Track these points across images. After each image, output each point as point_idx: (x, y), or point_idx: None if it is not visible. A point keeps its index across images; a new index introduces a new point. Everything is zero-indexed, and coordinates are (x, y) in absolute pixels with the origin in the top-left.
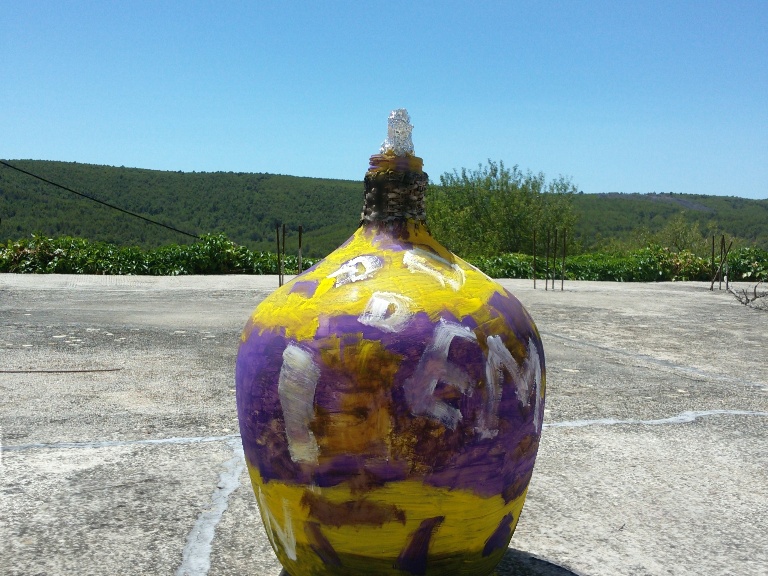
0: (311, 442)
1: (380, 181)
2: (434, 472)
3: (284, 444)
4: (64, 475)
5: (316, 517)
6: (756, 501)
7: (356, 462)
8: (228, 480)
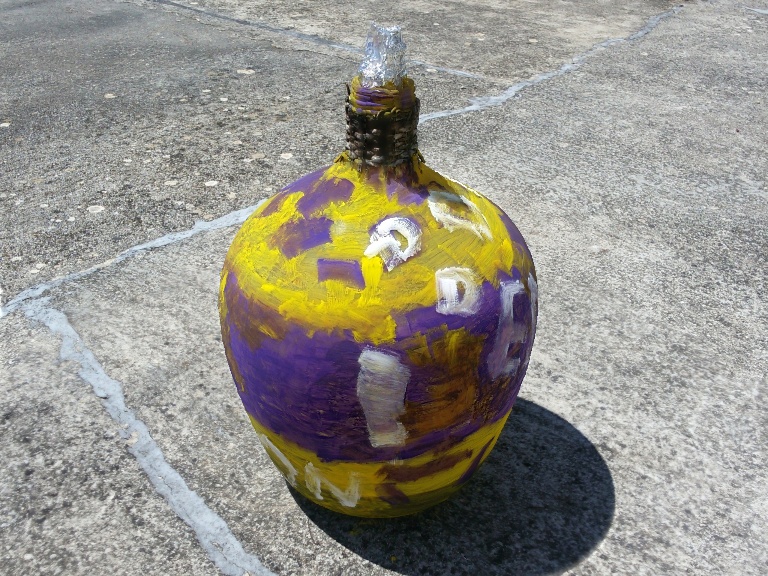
0: (399, 431)
1: (385, 122)
2: (498, 413)
3: (364, 436)
4: None
5: (393, 480)
6: (542, 245)
7: (443, 434)
8: (99, 381)
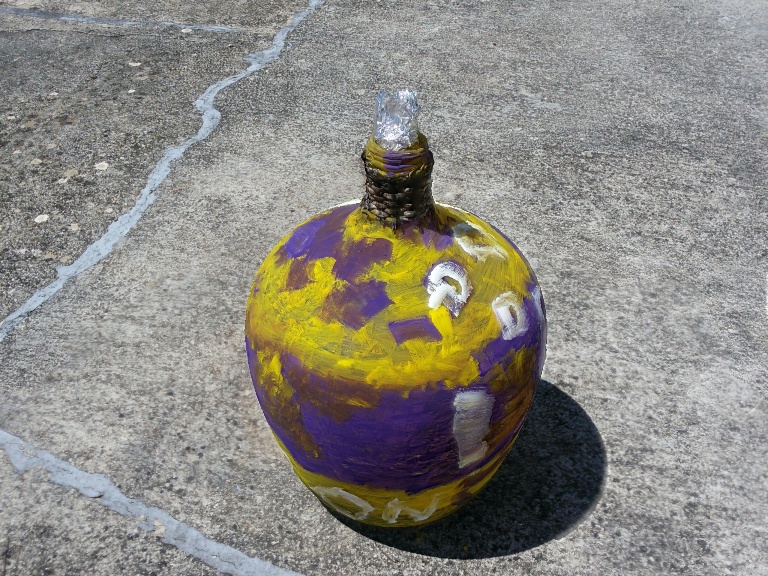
0: None
1: (416, 180)
2: None
3: None
4: None
5: None
6: None
7: None
8: (80, 481)
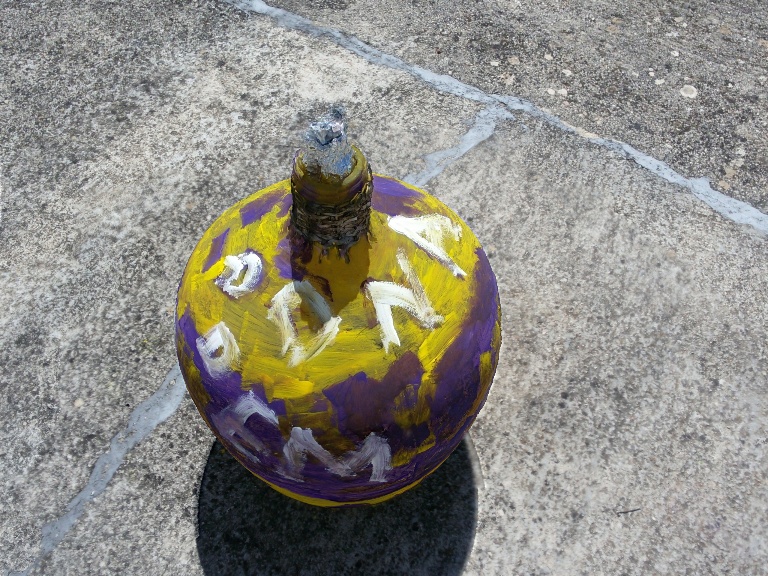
0: None
1: (292, 189)
2: None
3: None
4: (303, 105)
5: None
6: None
7: None
8: None
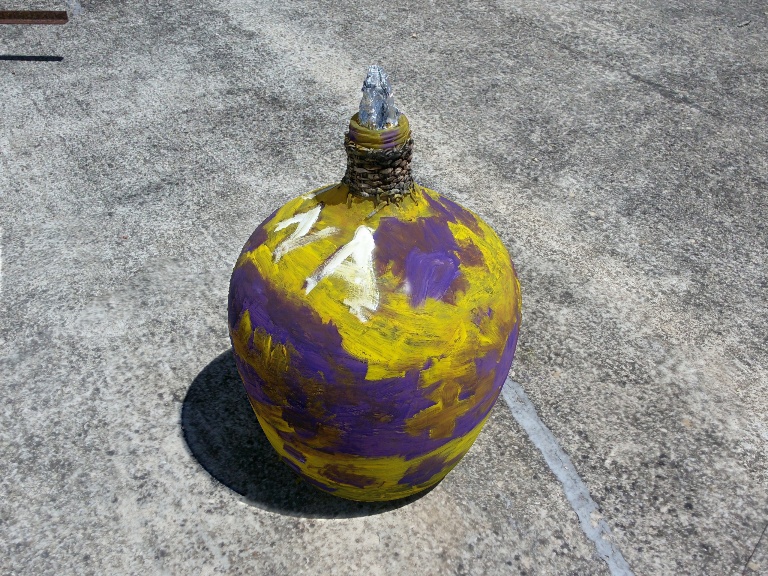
0: None
1: None
2: None
3: None
4: None
5: None
6: None
7: None
8: None
